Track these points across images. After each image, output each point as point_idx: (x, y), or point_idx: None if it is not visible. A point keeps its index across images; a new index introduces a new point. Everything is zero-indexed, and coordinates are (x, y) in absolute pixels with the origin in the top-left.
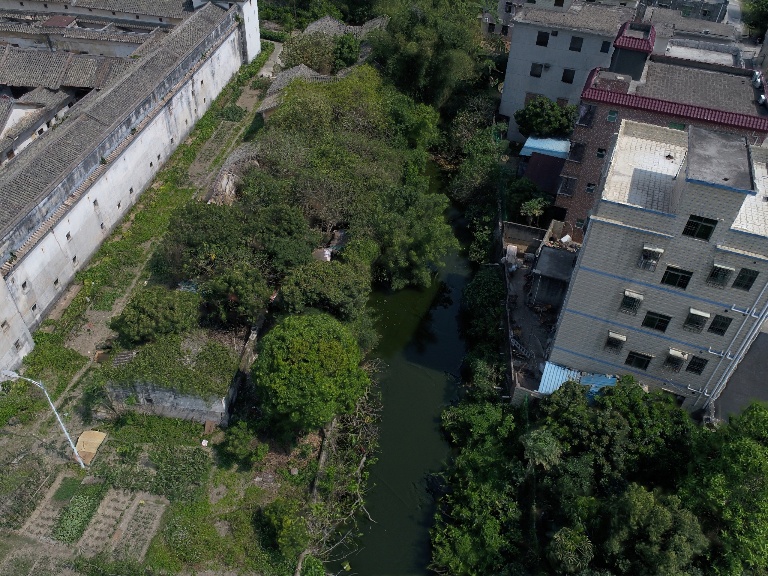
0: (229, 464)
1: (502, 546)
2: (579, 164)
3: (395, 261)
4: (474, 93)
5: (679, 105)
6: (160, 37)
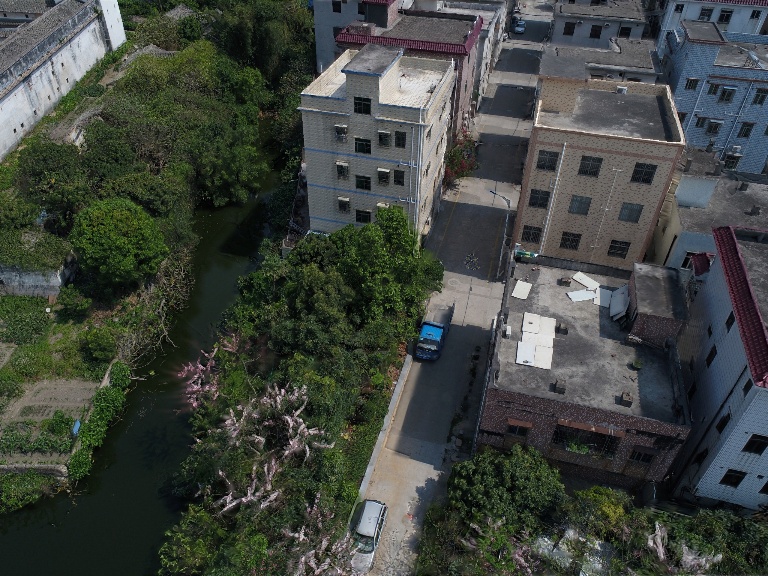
0: (66, 321)
1: (251, 335)
2: None
3: (212, 181)
4: (295, 57)
5: (402, 40)
6: None
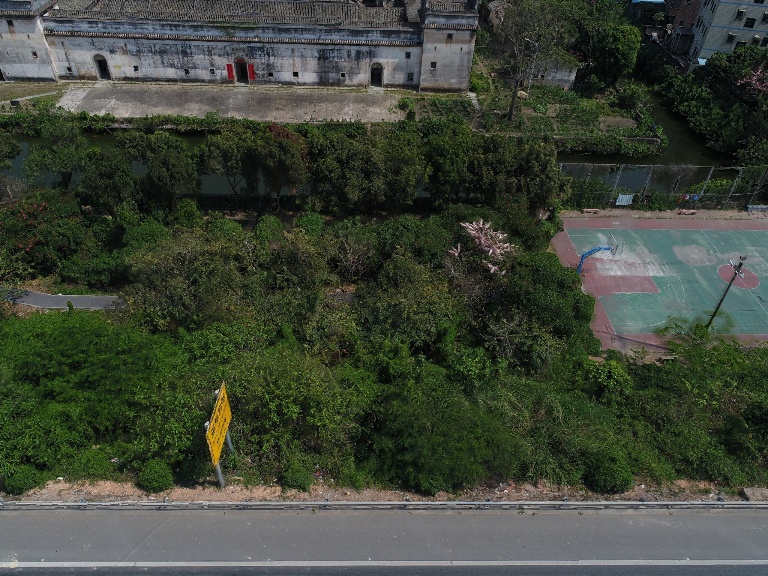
0: (582, 98)
1: (711, 96)
2: None
3: None
4: None
5: None
6: None
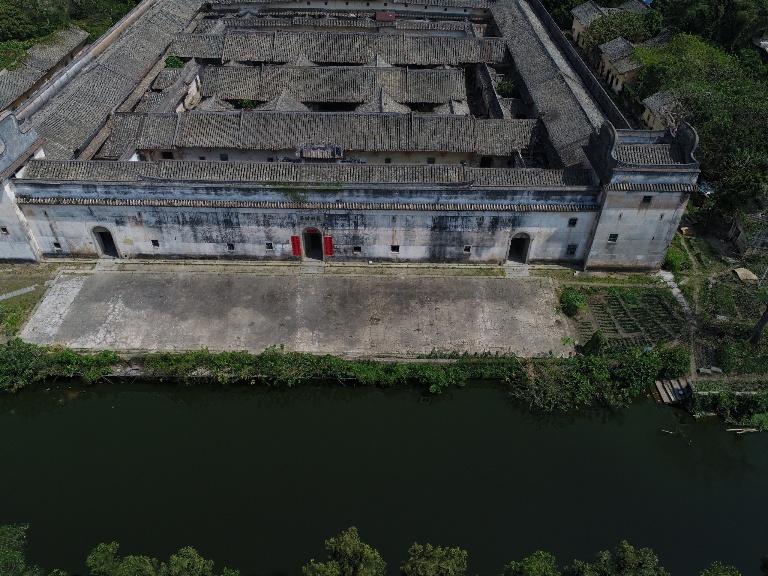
0: None
1: None
2: None
3: None
4: None
5: None
6: (479, 24)
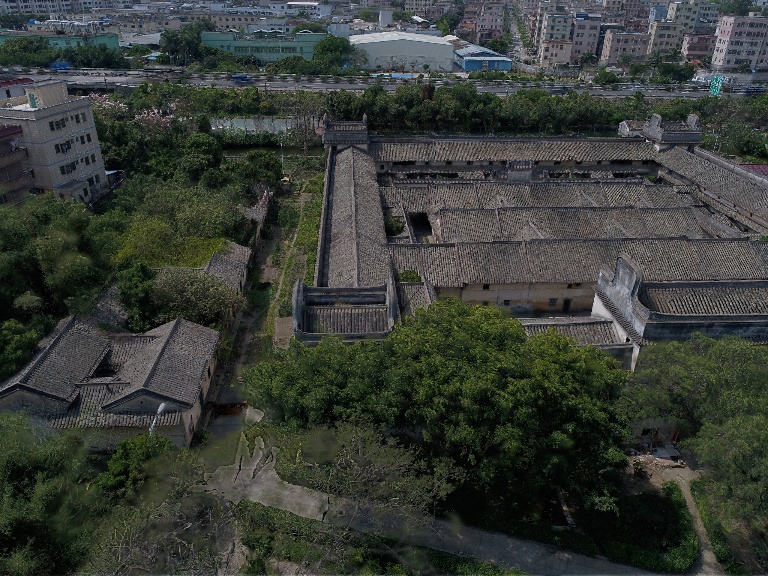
0: None
1: None
2: None
3: None
4: None
5: None
6: None
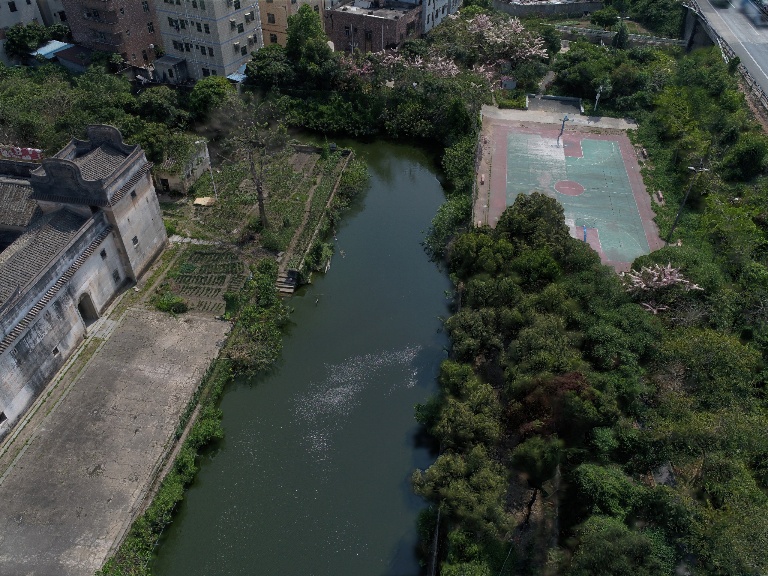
0: None
1: None
2: (118, 23)
3: None
4: None
5: None
6: None
